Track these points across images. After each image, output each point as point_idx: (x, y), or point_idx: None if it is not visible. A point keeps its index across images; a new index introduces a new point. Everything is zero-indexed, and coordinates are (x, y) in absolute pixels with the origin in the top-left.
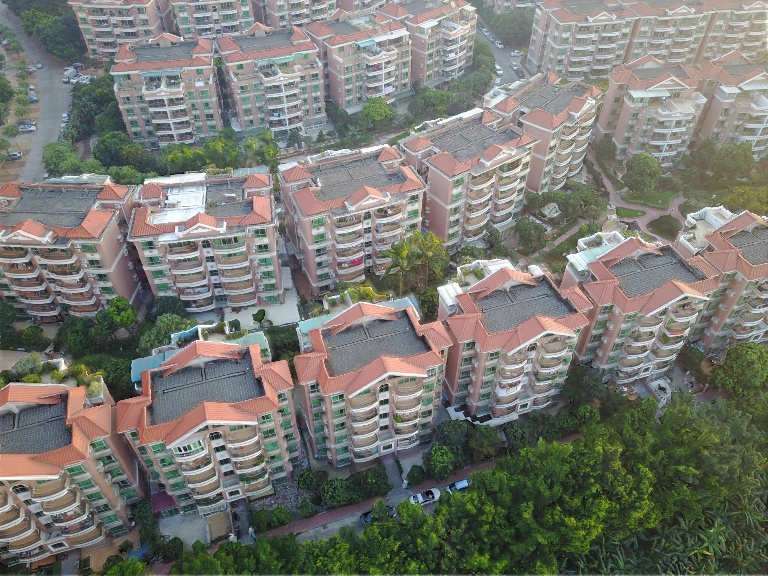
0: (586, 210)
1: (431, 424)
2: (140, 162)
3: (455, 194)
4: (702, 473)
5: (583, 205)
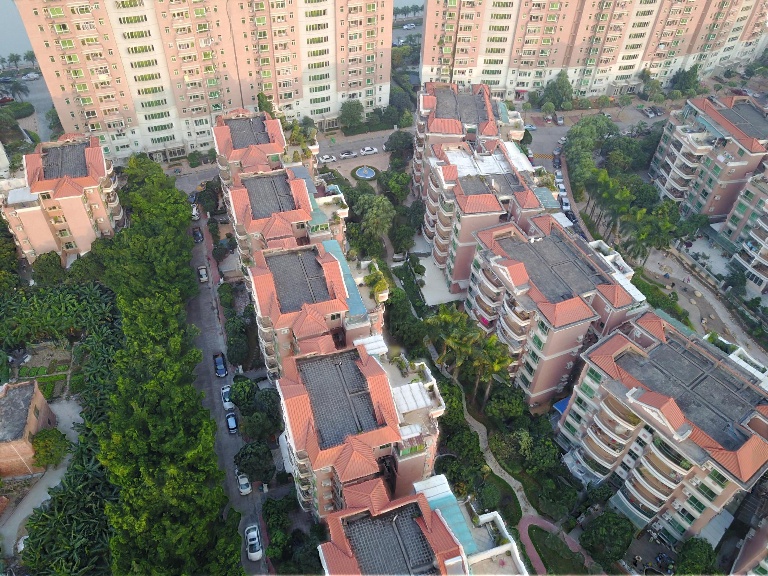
0: None
1: None
2: (609, 169)
3: (586, 382)
4: None
5: None
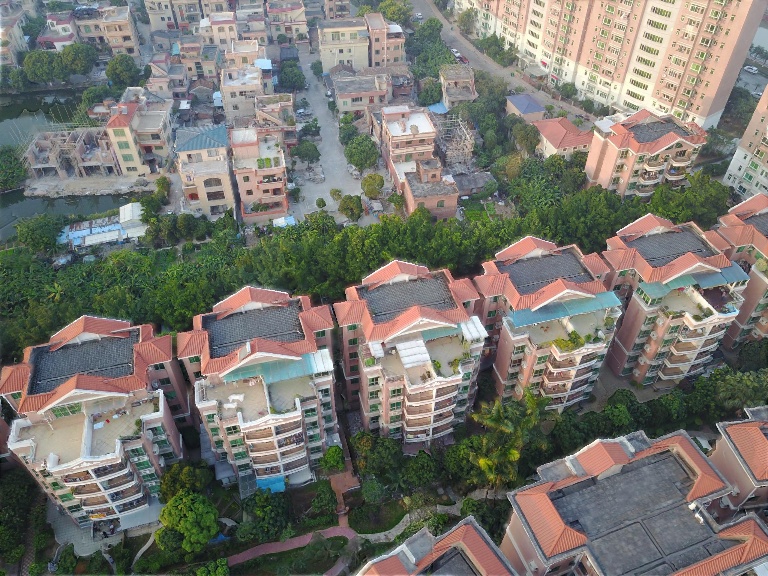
0: None
1: None
2: None
3: None
4: (293, 249)
5: None
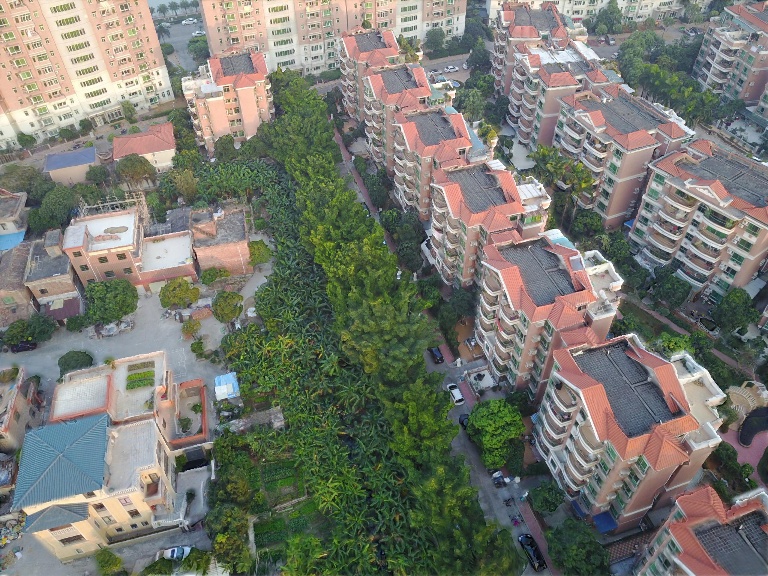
0: (763, 363)
1: (420, 217)
2: None
3: (652, 188)
4: None
5: (765, 354)
